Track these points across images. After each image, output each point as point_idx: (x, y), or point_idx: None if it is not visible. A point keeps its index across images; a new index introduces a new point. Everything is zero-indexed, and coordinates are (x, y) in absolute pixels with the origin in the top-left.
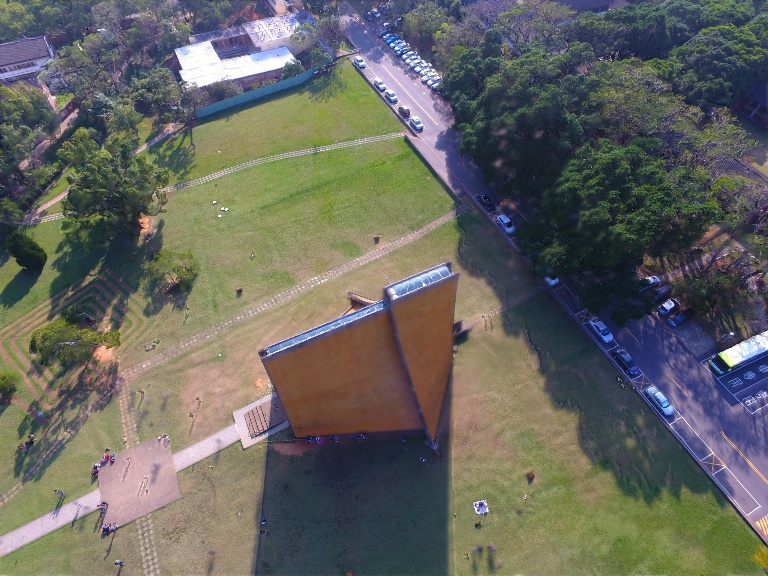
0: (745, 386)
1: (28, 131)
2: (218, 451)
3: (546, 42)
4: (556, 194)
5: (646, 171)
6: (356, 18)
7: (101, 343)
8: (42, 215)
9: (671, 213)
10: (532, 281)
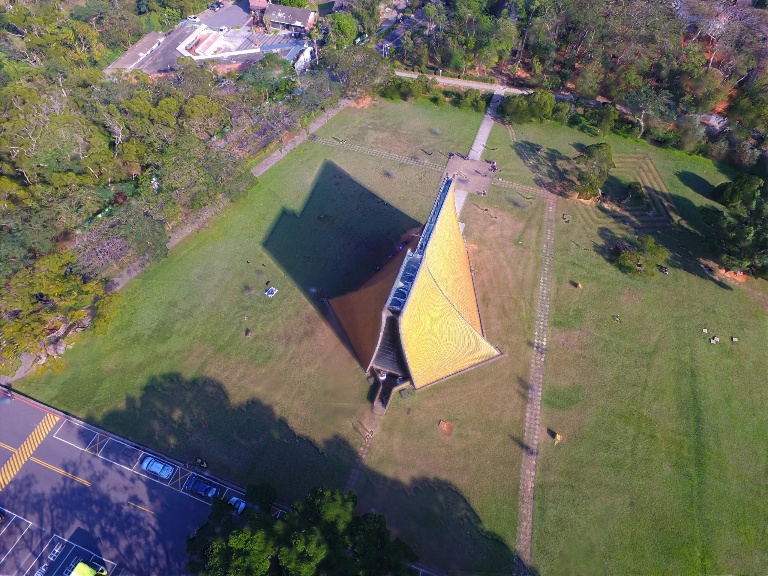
0: (61, 570)
1: None
2: None
3: None
4: None
5: None
6: None
7: None
8: None
9: None
10: None
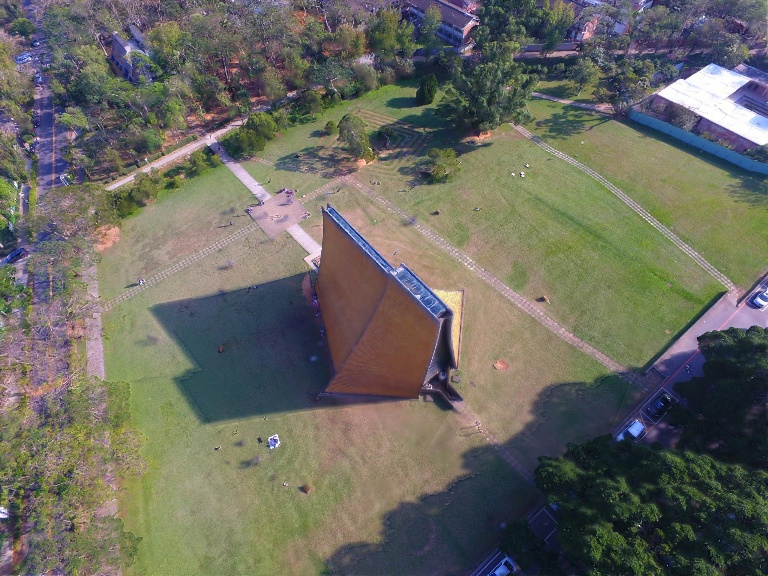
0: None
1: (522, 32)
2: (301, 246)
3: None
4: None
5: None
6: None
7: (363, 152)
8: None
9: None
10: None
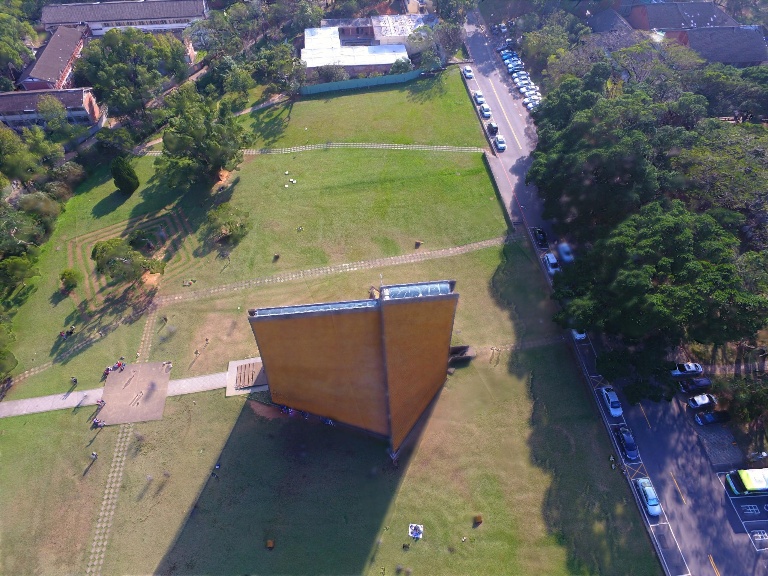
0: (761, 517)
1: (158, 76)
2: (205, 391)
3: (659, 87)
4: (606, 246)
5: (711, 246)
6: (482, 29)
7: (148, 268)
8: (149, 149)
9: (720, 298)
10: (557, 329)
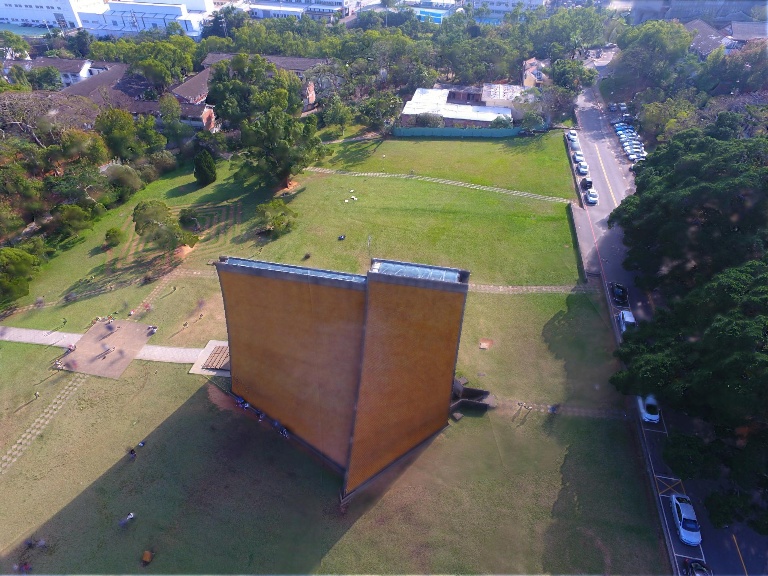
0: None
1: None
2: (173, 362)
3: None
4: None
5: None
6: (599, 106)
7: (180, 238)
8: None
9: None
10: (618, 401)
